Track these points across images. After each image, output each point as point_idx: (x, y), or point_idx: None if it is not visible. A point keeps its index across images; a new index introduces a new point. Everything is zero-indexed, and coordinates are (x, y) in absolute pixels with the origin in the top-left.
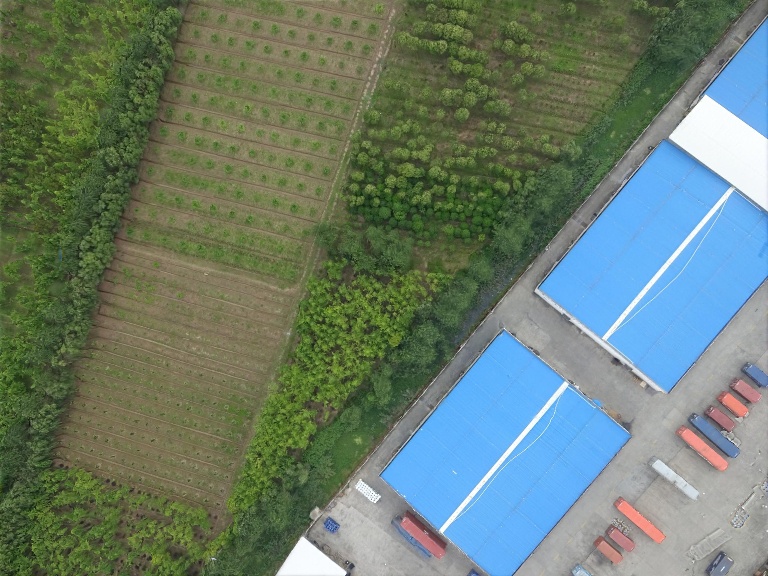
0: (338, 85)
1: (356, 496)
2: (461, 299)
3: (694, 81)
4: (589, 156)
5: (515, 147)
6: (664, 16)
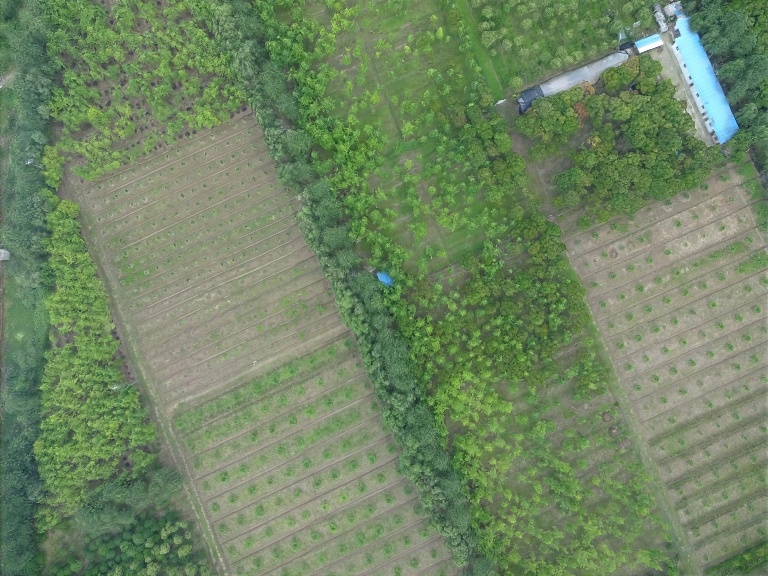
0: None
1: None
2: (9, 526)
3: None
4: None
5: None
6: None
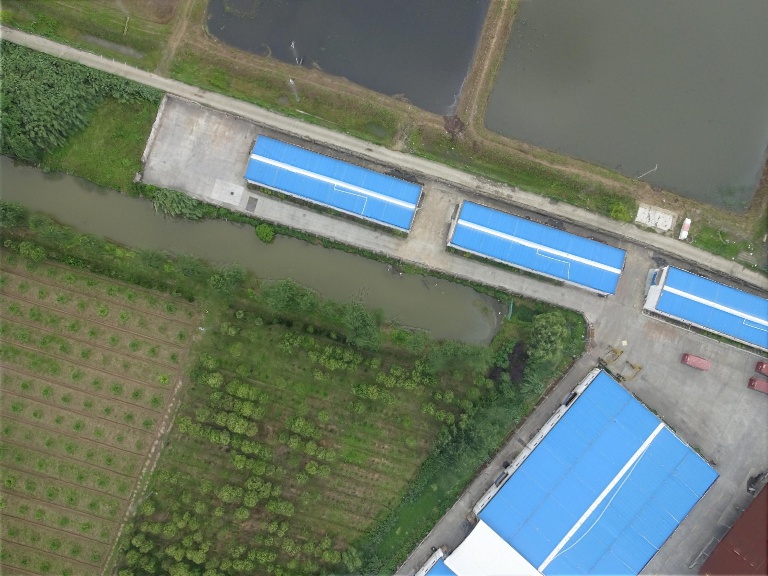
0: (115, 460)
1: None
2: None
3: (479, 482)
4: (372, 559)
5: (295, 552)
6: (449, 424)
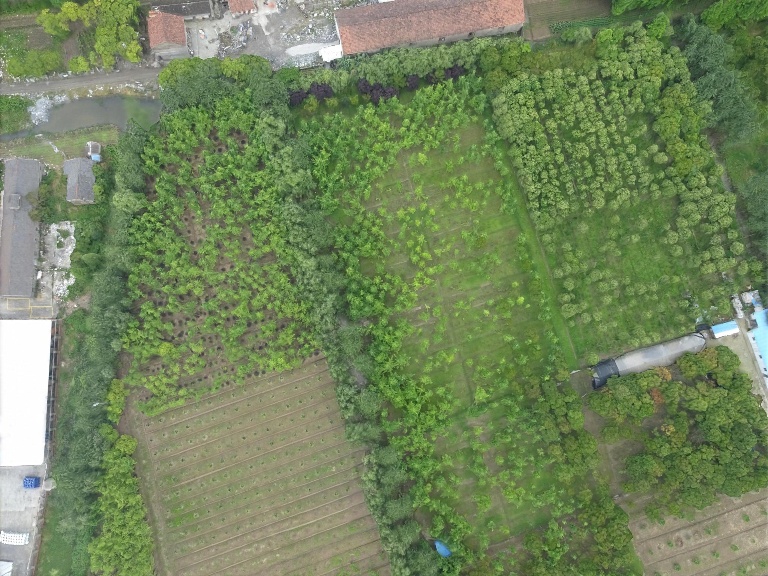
0: None
1: (25, 523)
2: None
3: None
4: None
5: None
6: None
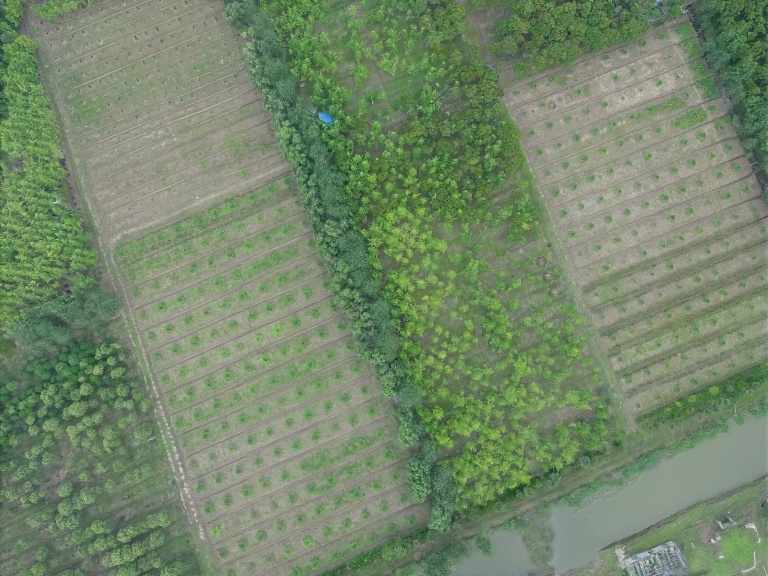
0: None
1: None
2: None
3: None
4: None
5: (1, 494)
6: None
